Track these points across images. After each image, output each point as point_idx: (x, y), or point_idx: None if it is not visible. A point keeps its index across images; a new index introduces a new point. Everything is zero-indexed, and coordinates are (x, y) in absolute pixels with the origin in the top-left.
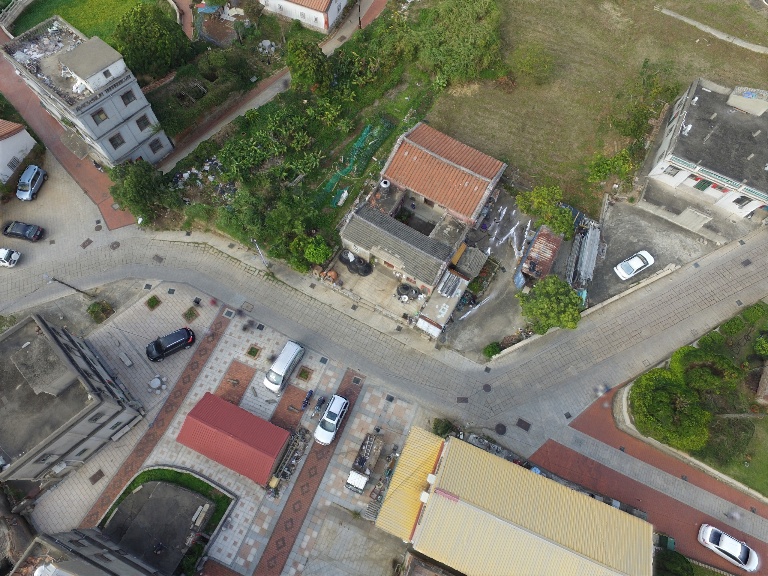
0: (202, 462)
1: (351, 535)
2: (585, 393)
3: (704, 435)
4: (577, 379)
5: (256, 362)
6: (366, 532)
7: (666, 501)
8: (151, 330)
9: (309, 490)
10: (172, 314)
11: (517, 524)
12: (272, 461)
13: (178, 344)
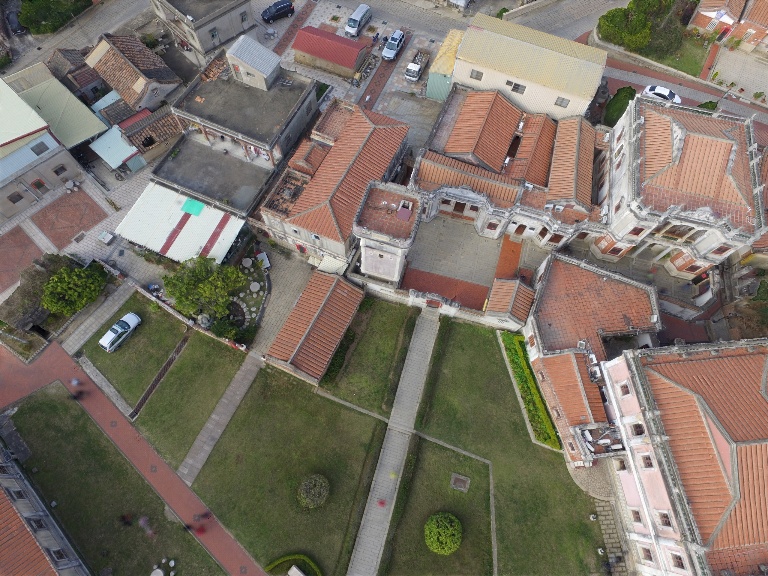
0: (307, 71)
1: (410, 104)
2: (568, 35)
3: (647, 33)
4: (563, 29)
5: (338, 24)
6: (420, 103)
7: (622, 83)
8: (262, 8)
9: (380, 84)
10: (276, 0)
11: (521, 40)
12: (358, 51)
13: (284, 8)
